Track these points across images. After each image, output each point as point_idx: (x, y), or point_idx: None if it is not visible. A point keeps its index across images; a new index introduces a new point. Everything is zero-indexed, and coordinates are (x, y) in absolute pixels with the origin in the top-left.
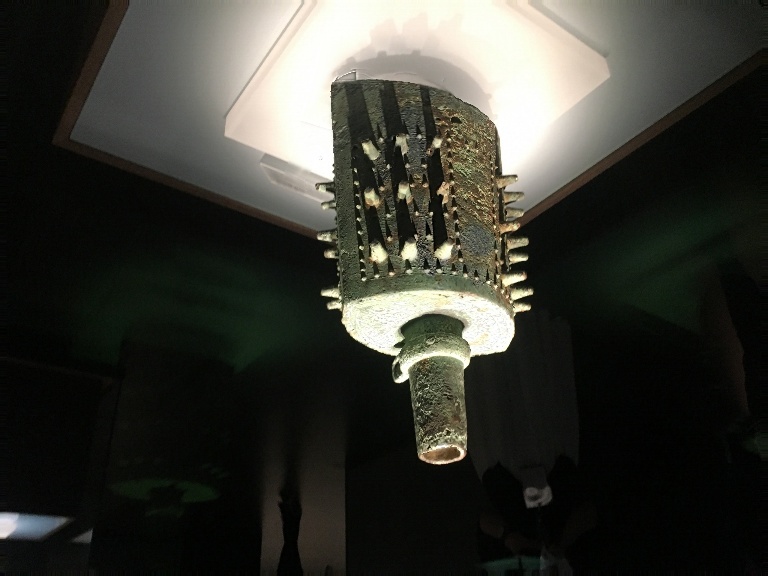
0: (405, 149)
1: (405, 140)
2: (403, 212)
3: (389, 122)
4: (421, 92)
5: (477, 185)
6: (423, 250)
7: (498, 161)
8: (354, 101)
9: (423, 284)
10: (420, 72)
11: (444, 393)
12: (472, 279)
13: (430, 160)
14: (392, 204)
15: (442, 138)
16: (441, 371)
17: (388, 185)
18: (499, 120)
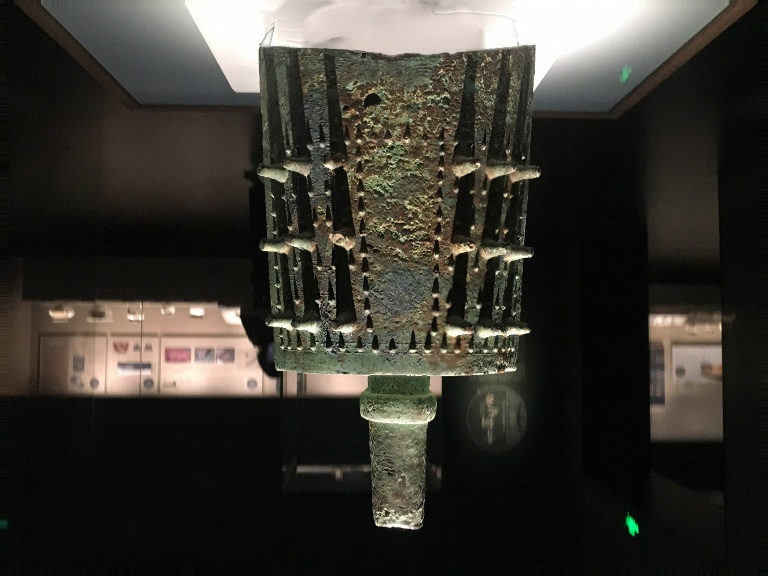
0: (305, 171)
1: (295, 165)
2: (306, 265)
3: (294, 122)
4: (325, 64)
5: (404, 201)
6: (325, 320)
7: (469, 121)
8: (270, 83)
9: (325, 366)
10: (349, 1)
11: (384, 468)
12: (385, 353)
13: (334, 182)
14: (298, 252)
15: (329, 161)
16: (382, 441)
17: (295, 223)
18: (518, 0)
